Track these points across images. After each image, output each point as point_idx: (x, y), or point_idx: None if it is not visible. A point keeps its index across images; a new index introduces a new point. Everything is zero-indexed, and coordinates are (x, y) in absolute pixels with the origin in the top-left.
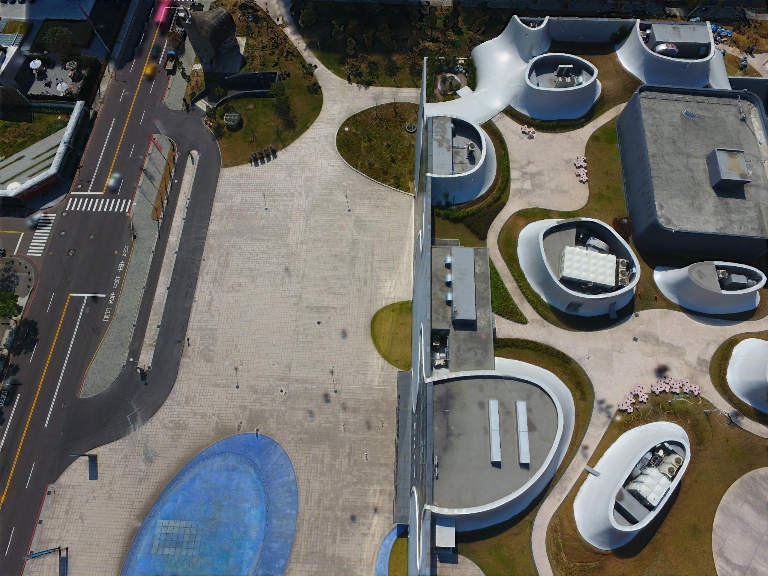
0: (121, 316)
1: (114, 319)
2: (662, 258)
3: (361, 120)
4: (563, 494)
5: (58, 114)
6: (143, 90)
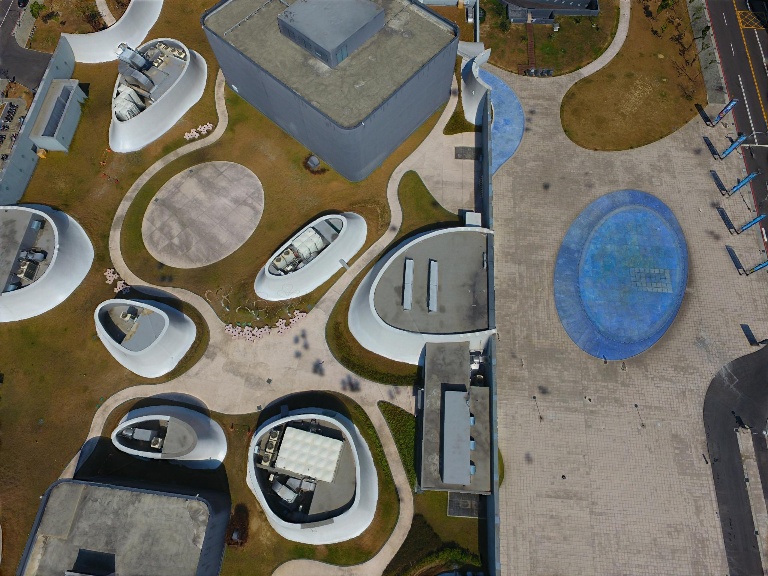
0: None
1: None
2: (204, 482)
3: None
4: (372, 250)
5: None
6: None
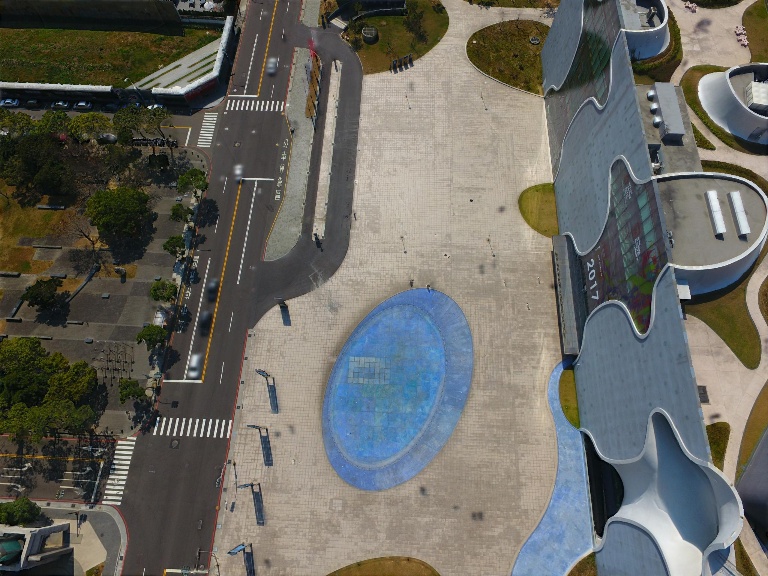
0: (291, 196)
1: (285, 198)
2: None
3: (487, 34)
4: (767, 270)
5: (206, 30)
6: (280, 10)
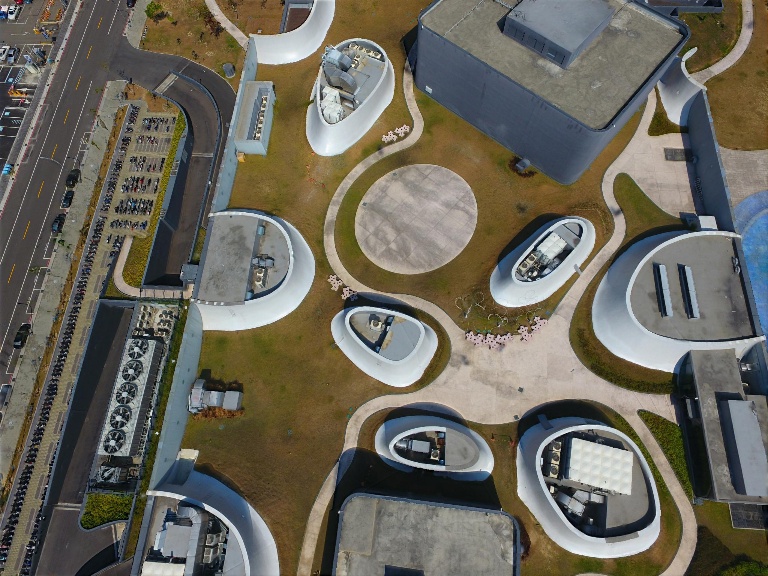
0: None
1: None
2: (472, 494)
3: None
4: (601, 254)
5: None
6: None
